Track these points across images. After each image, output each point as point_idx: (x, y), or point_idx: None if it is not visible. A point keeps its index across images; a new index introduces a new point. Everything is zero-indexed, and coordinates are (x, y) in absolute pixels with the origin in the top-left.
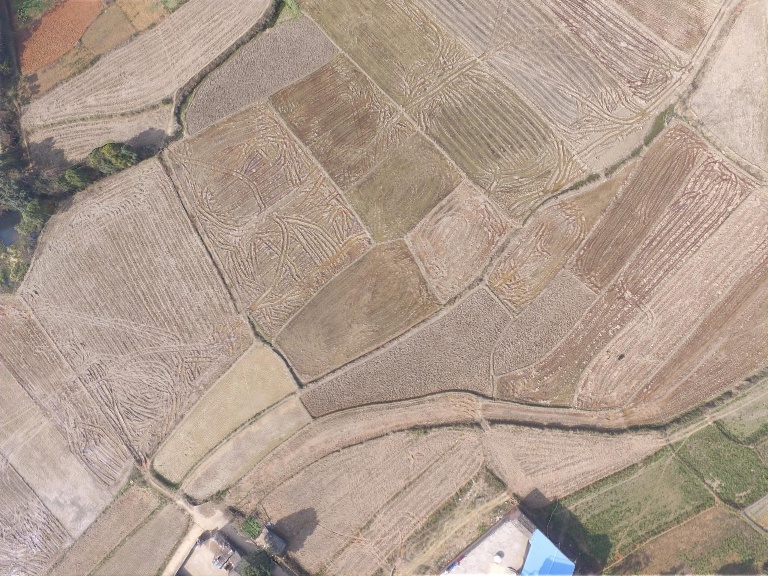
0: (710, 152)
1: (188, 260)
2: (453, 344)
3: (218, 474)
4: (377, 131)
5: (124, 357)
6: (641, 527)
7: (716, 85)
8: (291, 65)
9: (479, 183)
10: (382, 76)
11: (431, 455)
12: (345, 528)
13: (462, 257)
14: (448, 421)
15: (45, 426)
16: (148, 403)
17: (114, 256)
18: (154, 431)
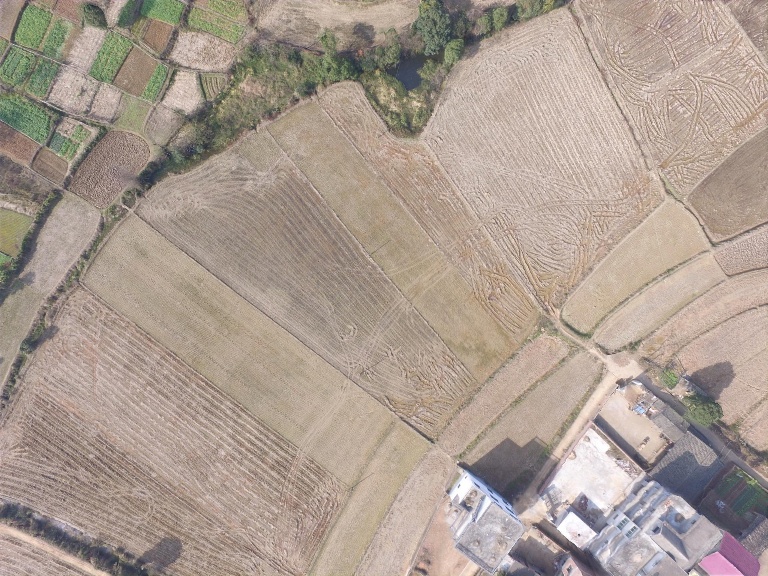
0: None
1: (598, 114)
2: None
3: (630, 326)
4: None
5: (531, 208)
6: None
7: None
8: None
9: None
10: None
11: None
12: (762, 382)
13: None
14: None
15: (449, 272)
16: (555, 254)
17: (521, 106)
18: (561, 282)
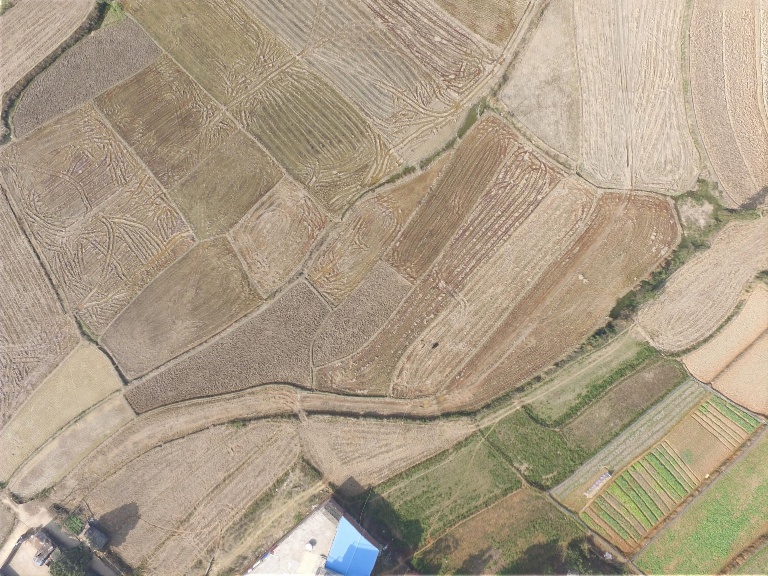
0: (521, 142)
1: (16, 262)
2: (274, 337)
3: (44, 472)
4: (200, 130)
5: None
6: (452, 511)
7: (526, 77)
8: (116, 67)
9: (299, 178)
10: (204, 75)
11: (250, 447)
12: (166, 521)
13: (283, 252)
14: (267, 413)
15: None
16: None
17: None
18: None
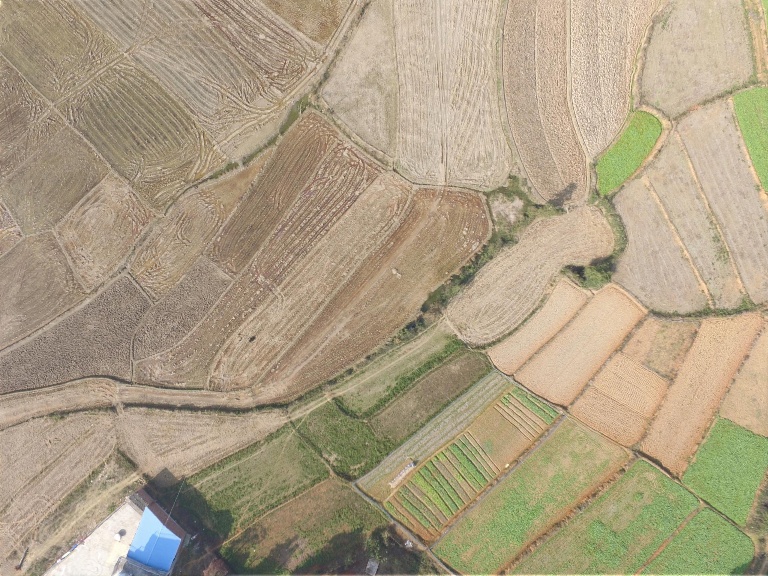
0: (340, 139)
1: None
2: (95, 331)
3: None
4: (28, 126)
5: None
6: (262, 502)
7: (346, 74)
8: None
9: (124, 174)
10: (33, 72)
11: (68, 439)
12: None
13: (107, 247)
14: (86, 406)
15: None
16: None
17: None
18: None
